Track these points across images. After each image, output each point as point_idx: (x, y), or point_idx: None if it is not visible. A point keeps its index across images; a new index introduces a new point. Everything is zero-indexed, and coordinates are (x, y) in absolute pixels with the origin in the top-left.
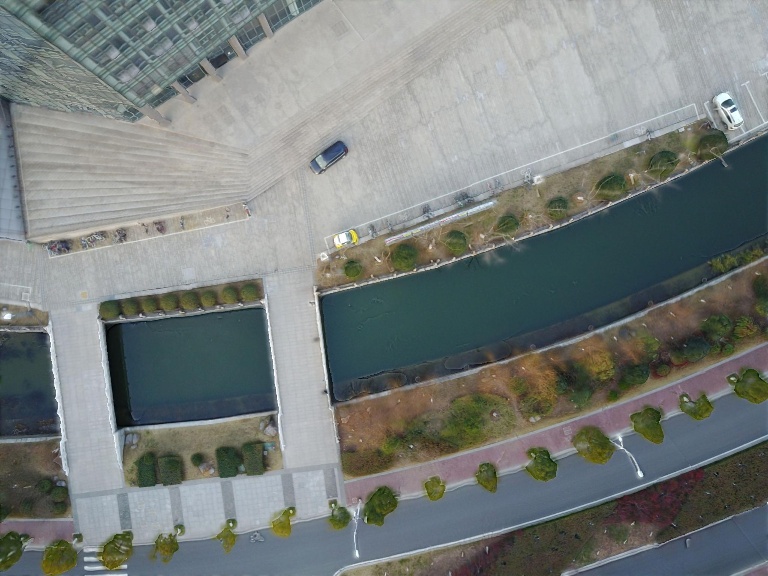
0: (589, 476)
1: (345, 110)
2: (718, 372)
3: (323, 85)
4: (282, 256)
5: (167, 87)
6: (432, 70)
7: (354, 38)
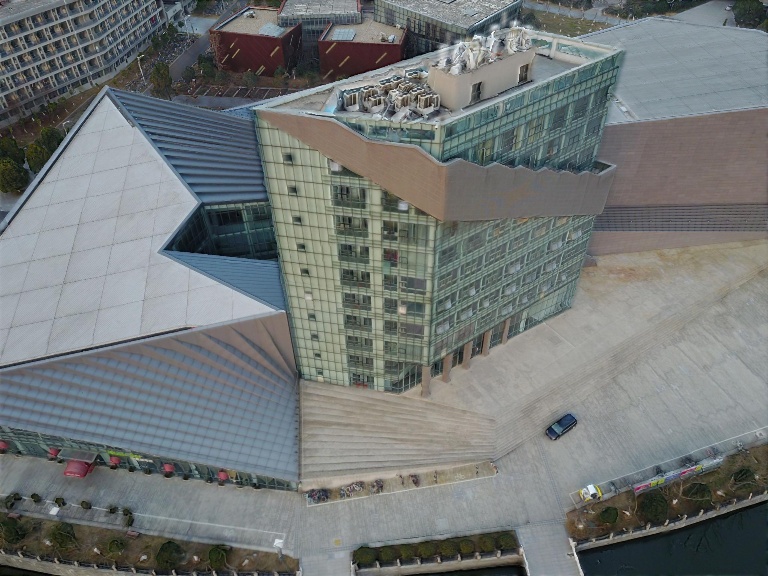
0: None
1: (569, 393)
2: None
3: (550, 374)
4: (532, 509)
5: (435, 365)
6: (630, 370)
7: (567, 346)
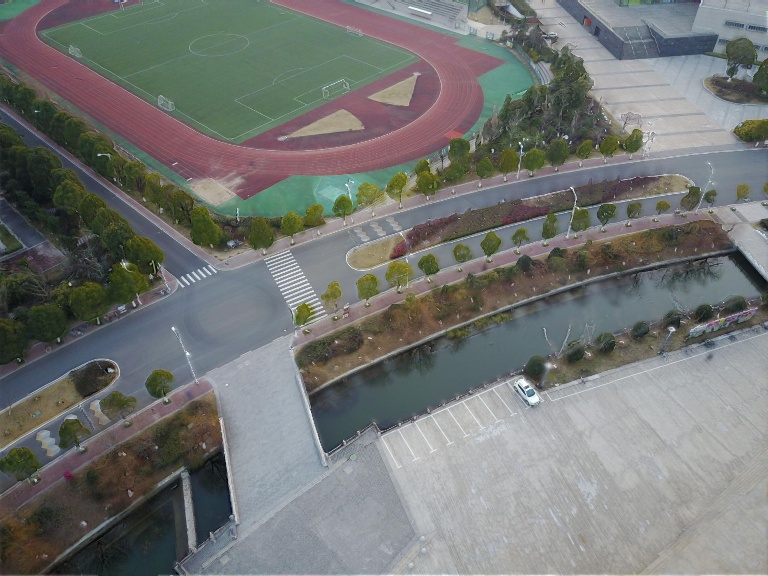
0: (567, 222)
1: None
2: (500, 263)
3: None
4: None
5: None
6: None
7: None
